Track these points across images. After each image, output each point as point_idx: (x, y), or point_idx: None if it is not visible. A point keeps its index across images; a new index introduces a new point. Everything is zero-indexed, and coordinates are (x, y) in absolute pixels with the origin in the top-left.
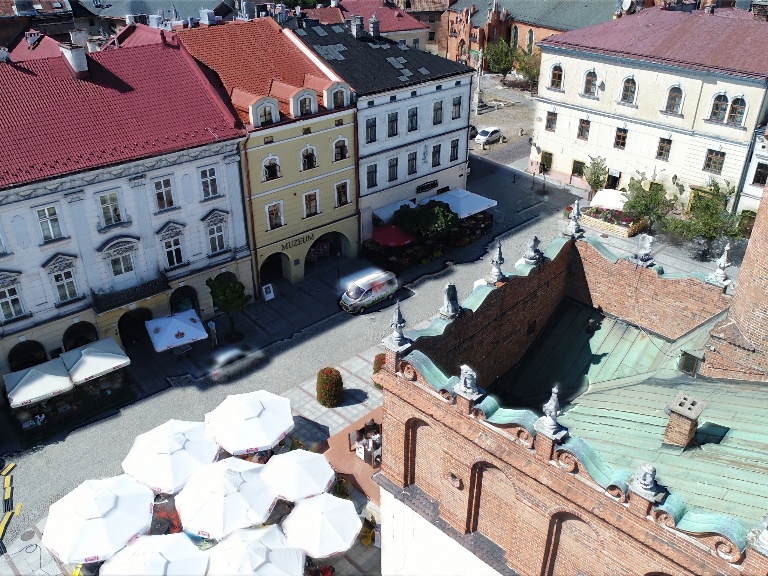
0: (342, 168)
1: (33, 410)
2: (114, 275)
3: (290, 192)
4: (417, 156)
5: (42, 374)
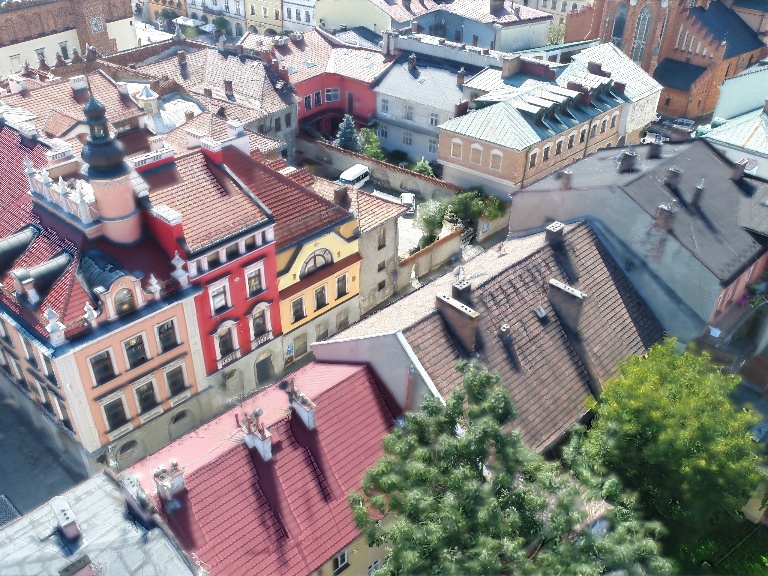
0: (277, 3)
1: (180, 28)
2: (213, 5)
3: (258, 3)
4: (310, 14)
5: (182, 18)
